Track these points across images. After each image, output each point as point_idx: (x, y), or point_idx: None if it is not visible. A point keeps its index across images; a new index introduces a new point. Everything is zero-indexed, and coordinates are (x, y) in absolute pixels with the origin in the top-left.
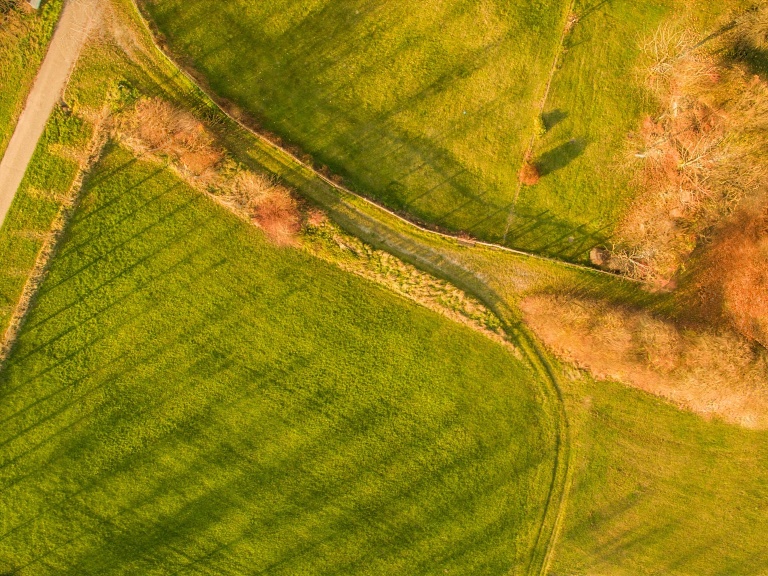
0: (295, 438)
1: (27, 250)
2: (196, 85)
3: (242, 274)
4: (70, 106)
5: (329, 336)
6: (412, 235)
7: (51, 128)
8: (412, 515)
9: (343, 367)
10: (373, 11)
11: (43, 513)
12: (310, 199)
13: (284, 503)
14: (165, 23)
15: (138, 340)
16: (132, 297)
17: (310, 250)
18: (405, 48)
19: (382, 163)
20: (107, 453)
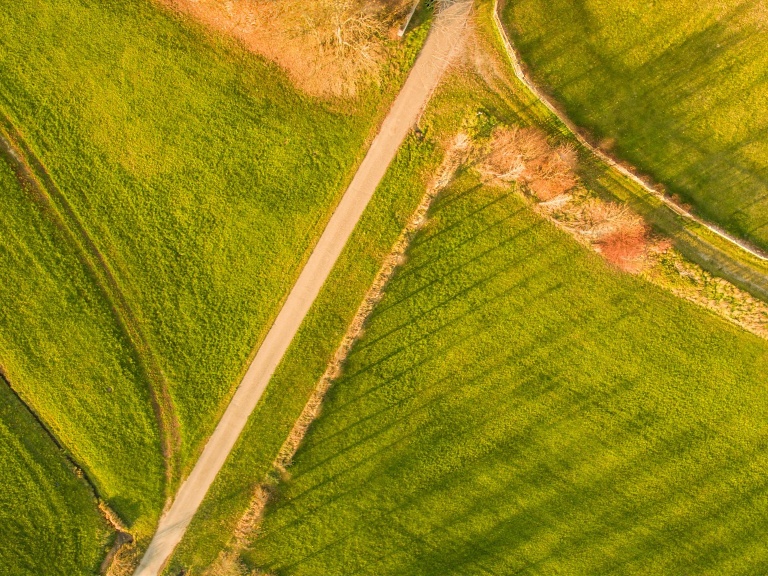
0: (611, 459)
1: (366, 272)
2: (555, 114)
3: (576, 298)
4: (424, 131)
5: (655, 360)
6: (749, 263)
7: (403, 153)
8: (718, 536)
9: (666, 390)
10: (735, 45)
11: (358, 530)
12: (654, 227)
13: (594, 523)
14: (528, 52)
15: (466, 361)
16: (464, 319)
17: (647, 276)
18: (762, 81)
19: (728, 193)
20: (425, 472)
